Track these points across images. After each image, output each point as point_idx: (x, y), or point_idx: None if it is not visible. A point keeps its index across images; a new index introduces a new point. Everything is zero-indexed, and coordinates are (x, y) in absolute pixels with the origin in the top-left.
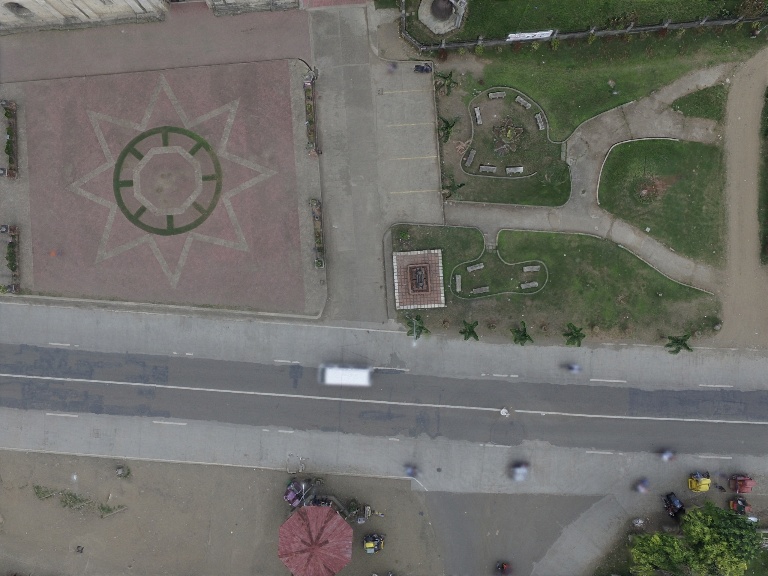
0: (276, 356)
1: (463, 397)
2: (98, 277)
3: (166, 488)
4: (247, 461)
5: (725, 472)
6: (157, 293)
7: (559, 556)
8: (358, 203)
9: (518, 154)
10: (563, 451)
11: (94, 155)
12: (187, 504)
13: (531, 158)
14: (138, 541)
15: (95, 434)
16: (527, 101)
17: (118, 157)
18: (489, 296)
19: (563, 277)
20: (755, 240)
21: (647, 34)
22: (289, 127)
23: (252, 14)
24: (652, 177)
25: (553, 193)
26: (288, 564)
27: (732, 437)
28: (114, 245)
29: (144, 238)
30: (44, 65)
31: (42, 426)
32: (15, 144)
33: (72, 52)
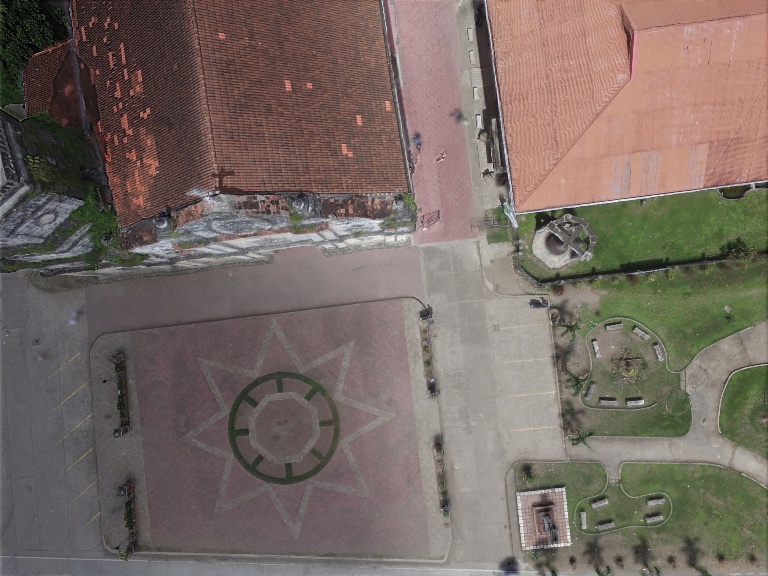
0: None
1: None
2: (217, 530)
3: None
4: None
5: None
6: (279, 544)
7: None
8: (479, 442)
9: (637, 385)
10: None
11: (207, 404)
12: None
13: (650, 388)
14: None
15: None
16: (644, 331)
17: (232, 406)
18: (614, 531)
19: (687, 509)
20: None
21: (764, 261)
22: (406, 368)
23: (362, 252)
24: None
25: (674, 424)
26: None
27: None
28: (232, 497)
29: (263, 488)
30: (151, 312)
31: None
32: (125, 397)
33: (179, 298)
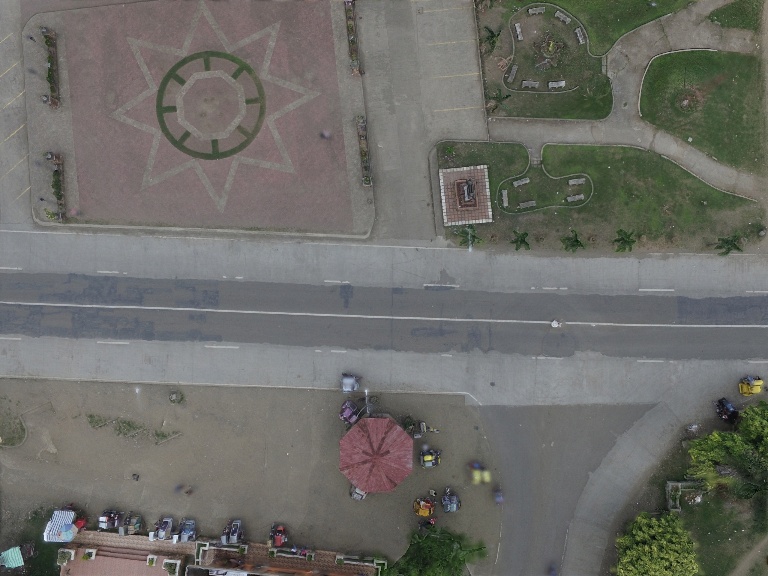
0: (326, 277)
1: (514, 311)
2: (145, 203)
3: (220, 412)
4: (301, 382)
5: None
6: (205, 218)
7: (614, 465)
8: (402, 122)
9: (559, 69)
10: (614, 361)
11: (136, 82)
12: (242, 428)
13: (572, 73)
14: (194, 467)
15: (147, 361)
16: (566, 16)
17: (160, 83)
18: (536, 210)
19: (608, 189)
20: None
21: None
22: (331, 48)
23: None
24: (692, 88)
25: (595, 106)
26: (349, 476)
27: None
28: (160, 171)
29: (189, 163)
30: None
31: (93, 355)
32: (56, 73)
33: None
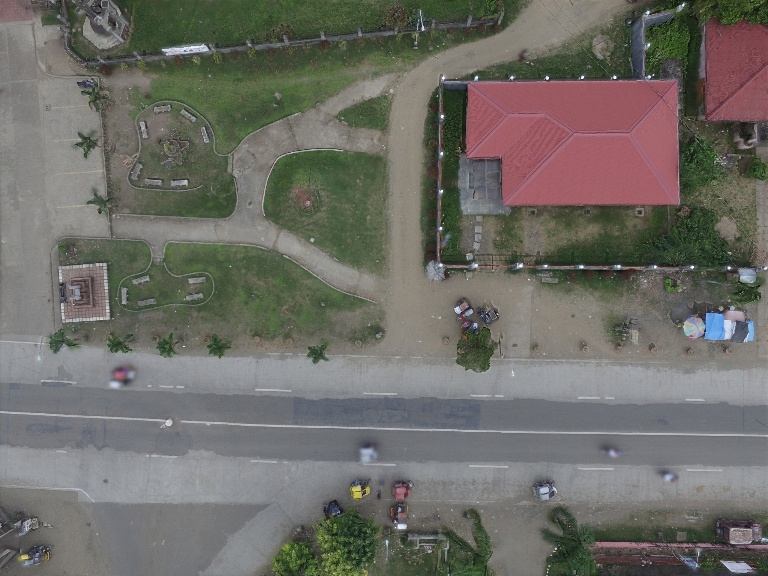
0: None
1: (129, 408)
2: None
3: None
4: None
5: (389, 479)
6: None
7: (225, 565)
8: (26, 218)
9: (185, 167)
10: (228, 461)
11: None
12: None
13: (198, 171)
14: None
15: None
16: (193, 114)
17: None
18: (156, 308)
19: (229, 288)
20: (418, 249)
21: (307, 46)
22: None
23: None
24: (317, 188)
25: (219, 205)
26: None
27: (396, 444)
28: None
29: None
30: None
31: None
32: None
33: None
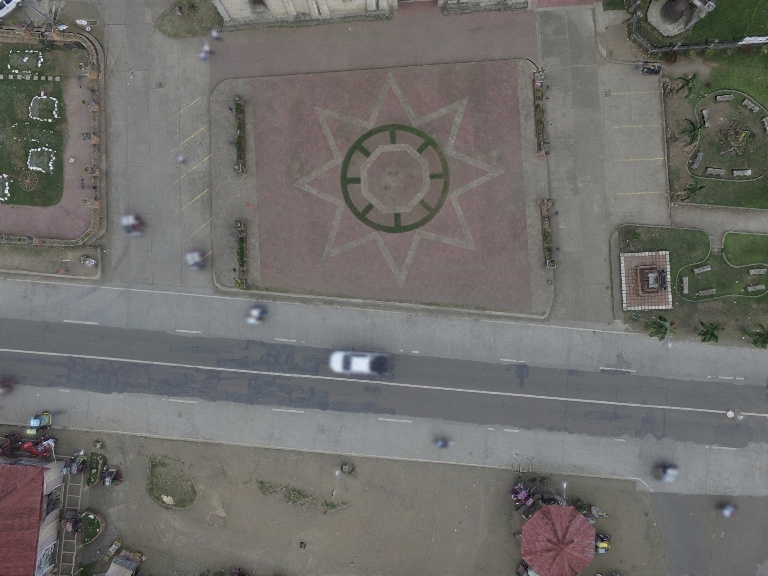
0: (502, 355)
1: (689, 399)
2: (325, 274)
3: (390, 485)
4: (472, 459)
5: None
6: (384, 290)
7: None
8: (585, 204)
9: (744, 157)
10: None
11: (322, 152)
12: (411, 501)
13: (757, 161)
14: (361, 538)
15: (321, 430)
16: (754, 104)
17: (346, 154)
18: (715, 298)
19: None
20: None
21: None
22: (517, 127)
23: (479, 14)
24: None
25: None
26: (531, 563)
27: None
28: (341, 242)
29: (371, 235)
30: (271, 61)
31: (268, 421)
32: (243, 140)
33: (299, 49)
